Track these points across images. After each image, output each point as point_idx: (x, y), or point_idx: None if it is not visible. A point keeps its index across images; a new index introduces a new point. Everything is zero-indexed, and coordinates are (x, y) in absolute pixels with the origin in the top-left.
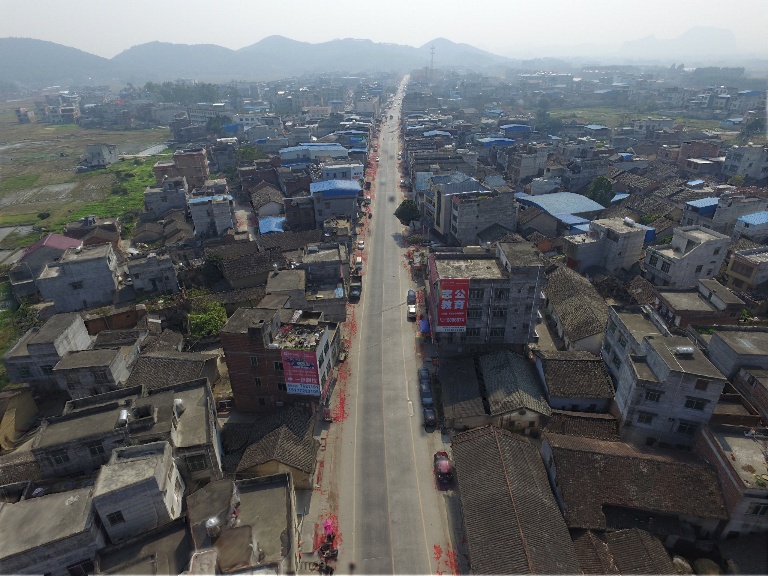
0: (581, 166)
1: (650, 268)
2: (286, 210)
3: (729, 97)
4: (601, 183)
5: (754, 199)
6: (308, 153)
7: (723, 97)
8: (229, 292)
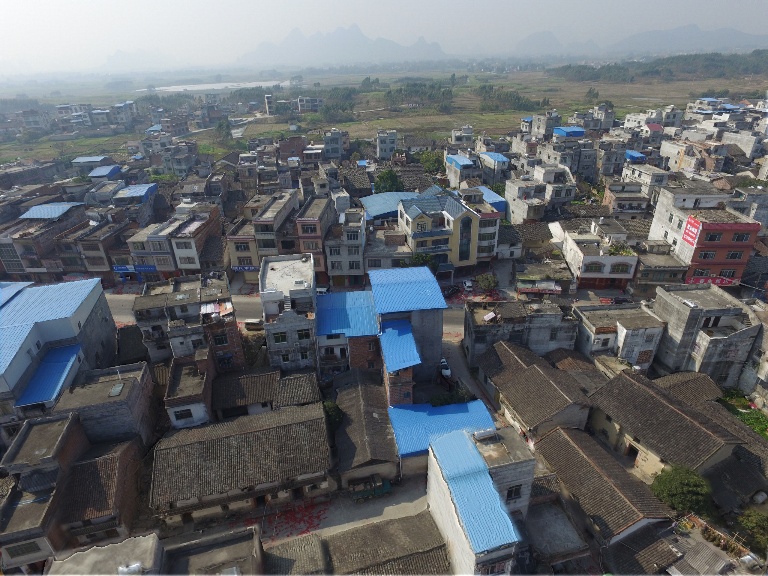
0: (337, 172)
1: (557, 200)
2: (412, 382)
3: (108, 112)
4: (393, 175)
5: (464, 151)
6: (45, 332)
7: (100, 113)
8: (766, 448)
